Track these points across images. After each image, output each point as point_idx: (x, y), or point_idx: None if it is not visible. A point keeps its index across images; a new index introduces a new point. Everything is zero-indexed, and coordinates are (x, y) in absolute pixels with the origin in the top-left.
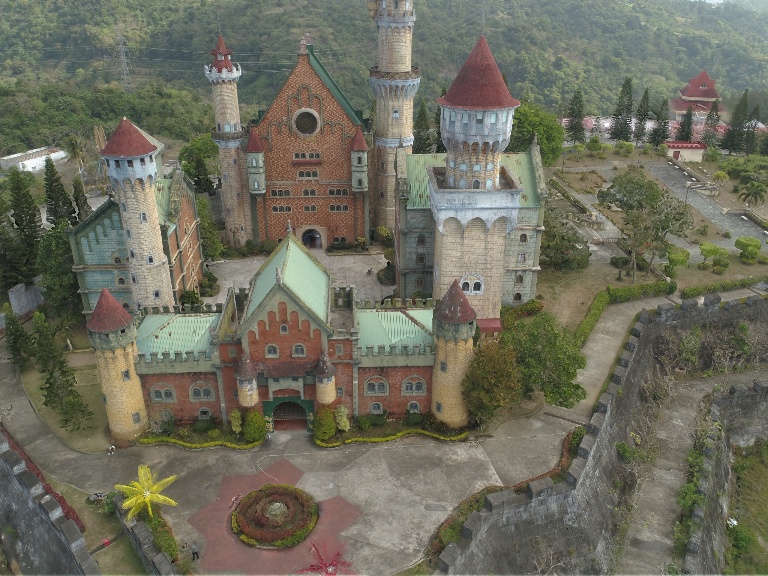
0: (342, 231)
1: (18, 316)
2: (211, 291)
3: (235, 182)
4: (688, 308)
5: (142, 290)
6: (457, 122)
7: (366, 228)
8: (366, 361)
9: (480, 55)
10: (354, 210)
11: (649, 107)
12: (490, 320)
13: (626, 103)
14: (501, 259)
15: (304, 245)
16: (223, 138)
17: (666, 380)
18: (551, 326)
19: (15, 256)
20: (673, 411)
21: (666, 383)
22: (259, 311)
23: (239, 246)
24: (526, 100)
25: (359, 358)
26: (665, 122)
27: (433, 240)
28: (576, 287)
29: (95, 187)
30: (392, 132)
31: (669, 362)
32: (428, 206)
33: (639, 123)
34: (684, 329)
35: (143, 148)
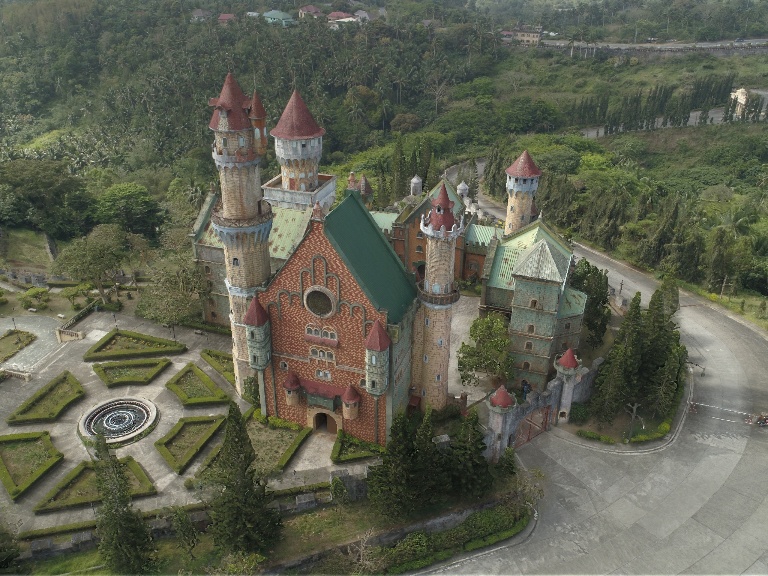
0: None
1: None
2: None
3: None
4: None
5: None
6: None
7: None
8: None
9: None
10: None
11: None
12: None
13: None
14: None
15: None
16: None
17: None
18: None
19: None
20: None
21: None
22: None
23: None
24: None
25: None
26: None
27: None
28: None
29: None
30: None
31: None
32: None
33: None
34: None
35: None
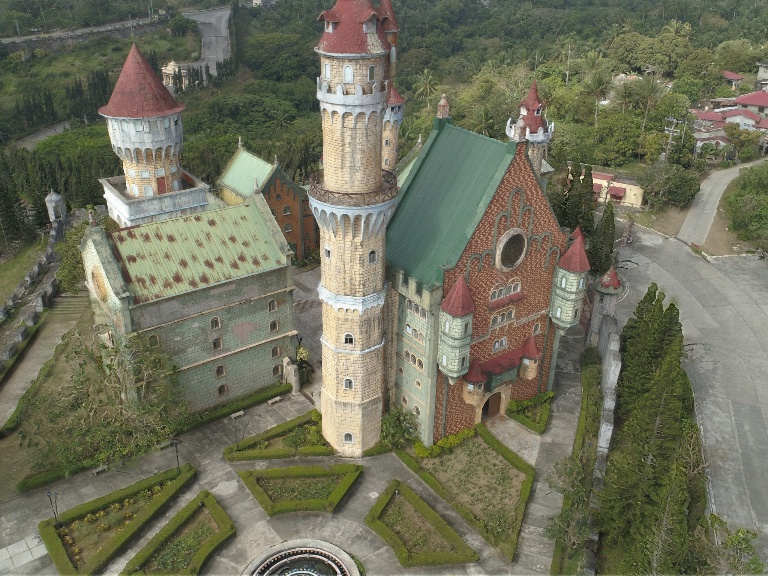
0: None
1: None
2: None
3: None
4: None
5: None
6: None
7: None
8: None
9: None
10: None
11: None
12: None
13: None
14: None
15: None
16: None
17: None
18: None
19: None
20: None
21: None
22: None
23: None
24: None
25: None
26: None
27: None
28: None
29: None
30: None
31: None
32: None
33: None
34: None
35: None
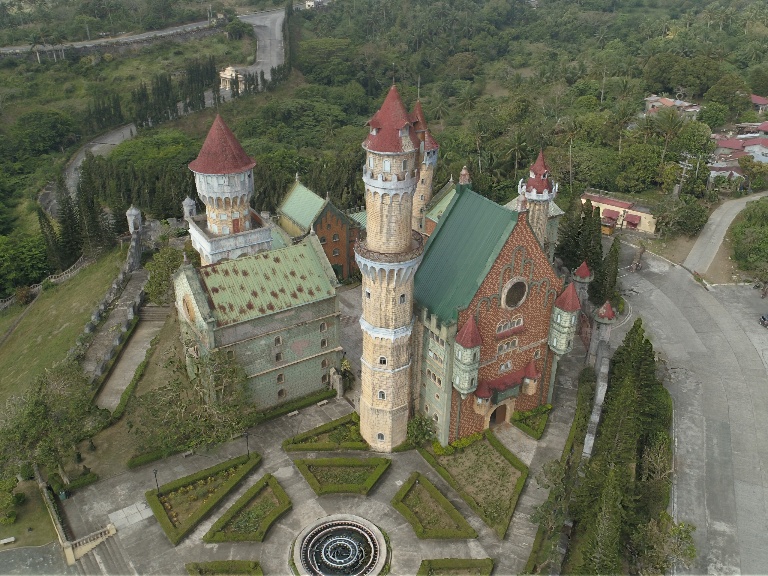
0: None
1: None
2: None
3: None
4: None
5: None
6: None
7: None
8: None
9: None
10: None
11: None
12: None
13: None
14: None
15: None
16: None
17: None
18: None
19: None
20: None
21: None
22: None
23: None
24: None
25: None
26: None
27: None
28: None
29: None
30: None
31: None
32: None
33: None
34: None
35: None
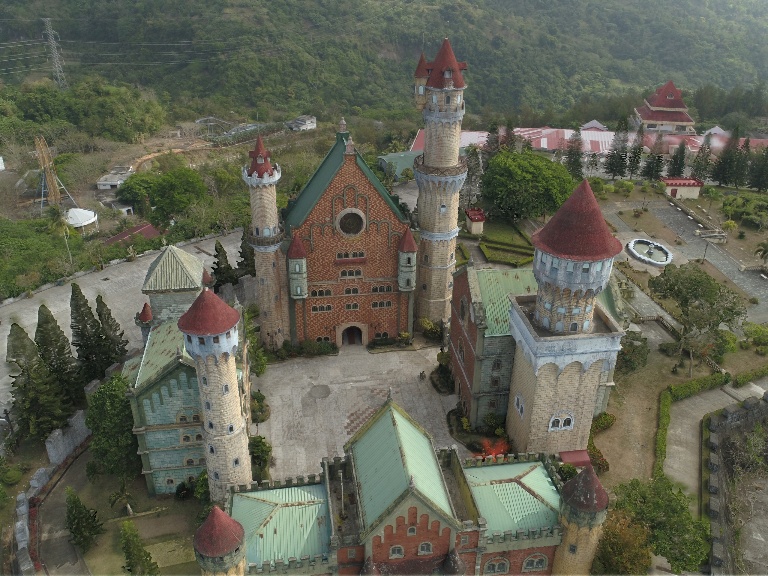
0: (384, 326)
1: (57, 466)
2: (262, 415)
3: (273, 285)
4: (751, 407)
5: (221, 460)
6: (560, 270)
7: (409, 322)
8: (491, 548)
9: (585, 200)
10: (397, 305)
11: (644, 142)
12: (577, 452)
13: (622, 139)
14: (594, 396)
15: (342, 340)
16: (262, 243)
17: (749, 499)
18: (670, 488)
19: (48, 399)
20: (750, 522)
21: (746, 499)
22: (388, 518)
23: (276, 348)
24: (529, 143)
25: (484, 546)
26: (659, 156)
27: (509, 364)
28: (636, 386)
29: (89, 262)
30: (438, 226)
31: (744, 473)
32: (506, 332)
33: (633, 157)
34: (747, 427)
35: (228, 320)
